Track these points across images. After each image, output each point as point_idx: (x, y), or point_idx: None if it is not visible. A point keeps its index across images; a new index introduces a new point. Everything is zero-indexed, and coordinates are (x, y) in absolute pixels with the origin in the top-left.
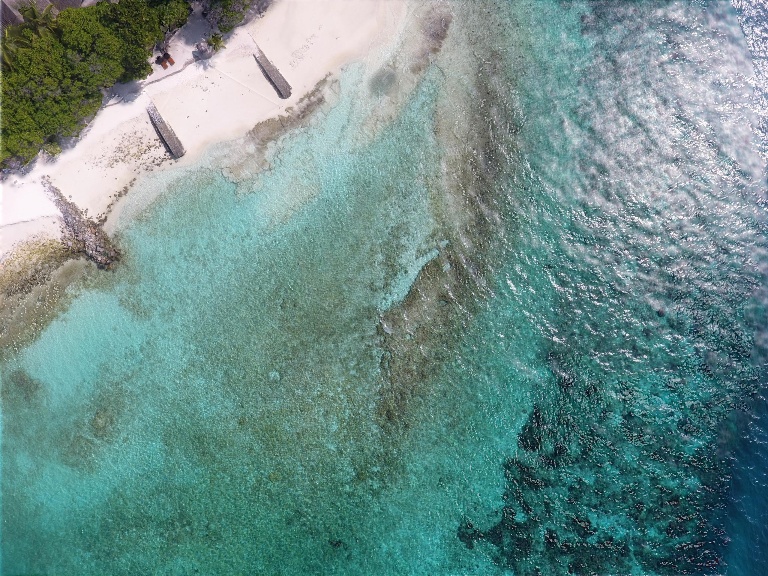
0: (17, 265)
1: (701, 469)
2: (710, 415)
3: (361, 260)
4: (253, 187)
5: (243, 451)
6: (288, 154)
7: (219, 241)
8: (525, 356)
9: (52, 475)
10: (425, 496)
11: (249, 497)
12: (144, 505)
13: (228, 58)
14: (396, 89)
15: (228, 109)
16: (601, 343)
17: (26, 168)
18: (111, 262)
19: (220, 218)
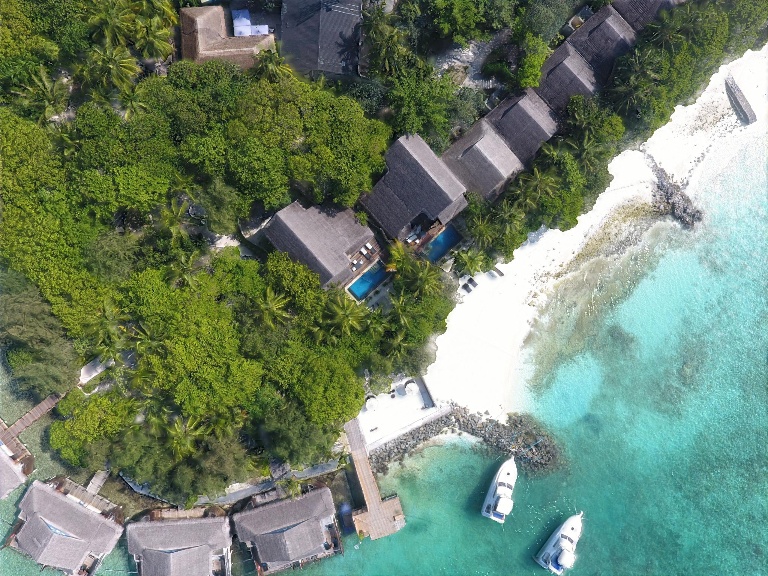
0: (613, 228)
1: None
2: None
3: None
4: None
5: None
6: None
7: None
8: None
9: (646, 422)
10: None
11: None
12: (726, 448)
13: None
14: None
15: None
16: None
17: None
18: None
19: None
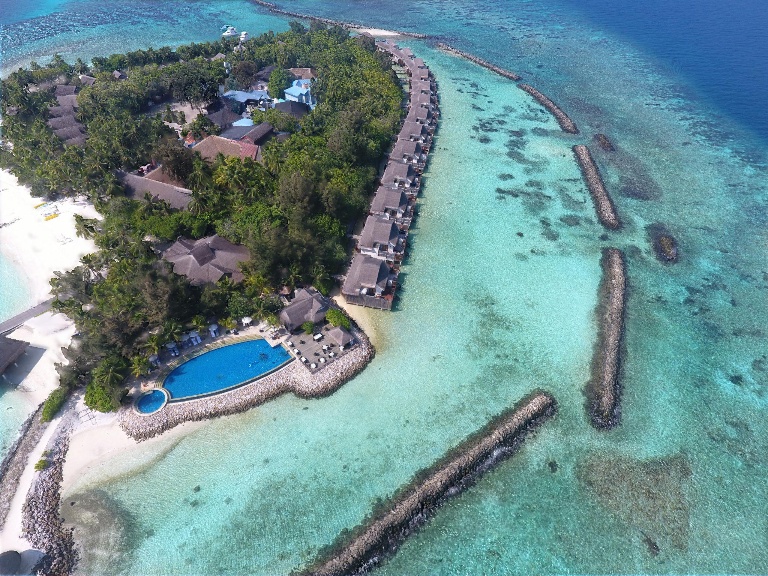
0: None
1: None
2: None
3: None
4: None
5: None
6: None
7: None
8: None
9: None
10: None
11: None
12: None
13: None
14: None
15: None
16: None
17: None
18: None
19: None
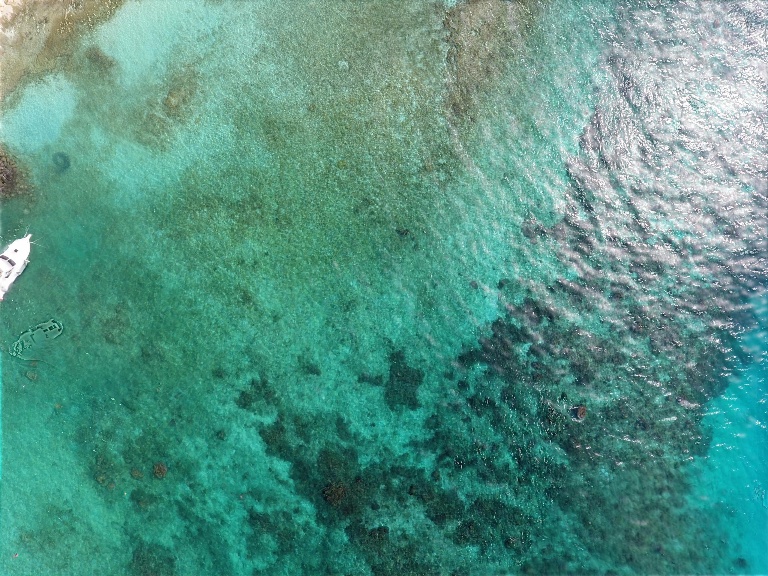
0: None
1: (756, 177)
2: (764, 125)
3: None
4: None
5: (313, 138)
6: None
7: None
8: (586, 60)
9: (125, 152)
10: (490, 190)
11: (318, 184)
12: (215, 186)
13: None
14: None
15: None
16: (659, 50)
17: None
18: None
19: None
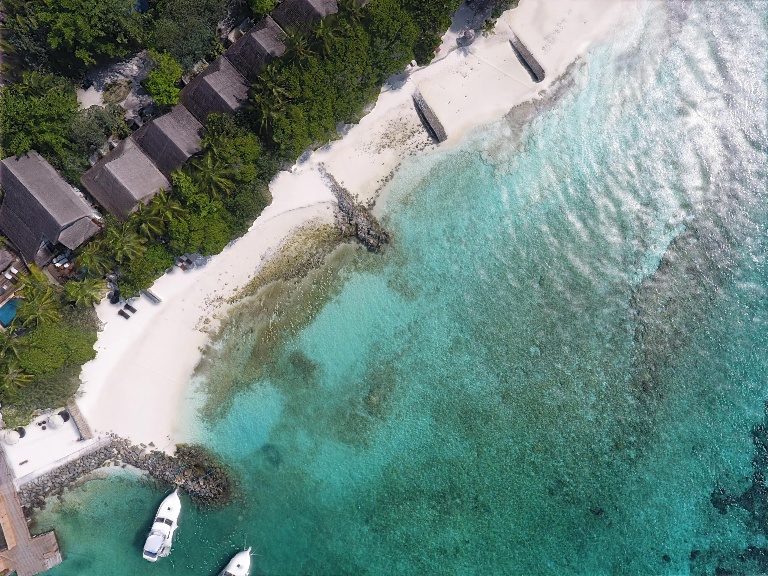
0: (293, 250)
1: None
2: None
3: (613, 237)
4: (510, 169)
5: (508, 425)
6: (541, 136)
7: (479, 222)
8: None
9: (330, 452)
10: (680, 464)
11: (514, 469)
12: (416, 479)
13: (486, 44)
14: (641, 70)
15: (485, 94)
16: None
17: (304, 156)
18: (381, 245)
19: (479, 200)
